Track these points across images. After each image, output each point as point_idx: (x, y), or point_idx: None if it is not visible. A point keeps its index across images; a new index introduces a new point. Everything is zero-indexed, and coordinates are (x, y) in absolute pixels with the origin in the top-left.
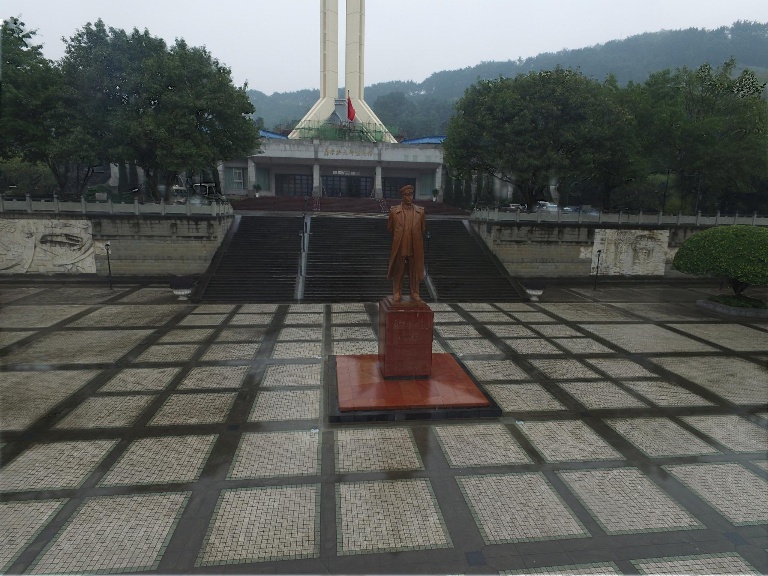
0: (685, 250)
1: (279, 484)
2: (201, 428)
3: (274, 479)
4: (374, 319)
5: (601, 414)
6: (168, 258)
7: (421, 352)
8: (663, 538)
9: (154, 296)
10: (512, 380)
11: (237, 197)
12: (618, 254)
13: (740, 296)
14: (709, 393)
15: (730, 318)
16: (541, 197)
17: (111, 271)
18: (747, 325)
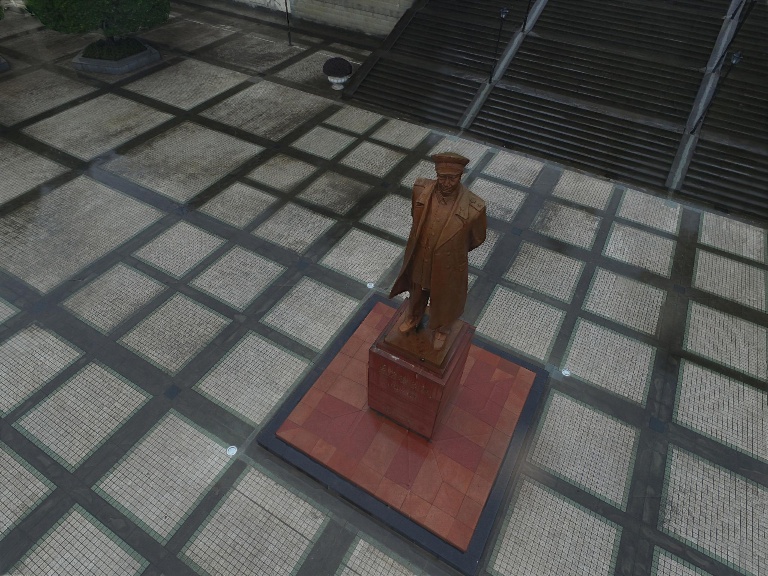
0: None
1: (119, 533)
2: (149, 374)
3: (123, 520)
4: (522, 214)
5: None
6: (358, 7)
7: (419, 413)
8: None
9: (317, 72)
10: (583, 492)
11: None
12: None
13: None
14: None
15: None
16: None
17: (303, 13)
18: None
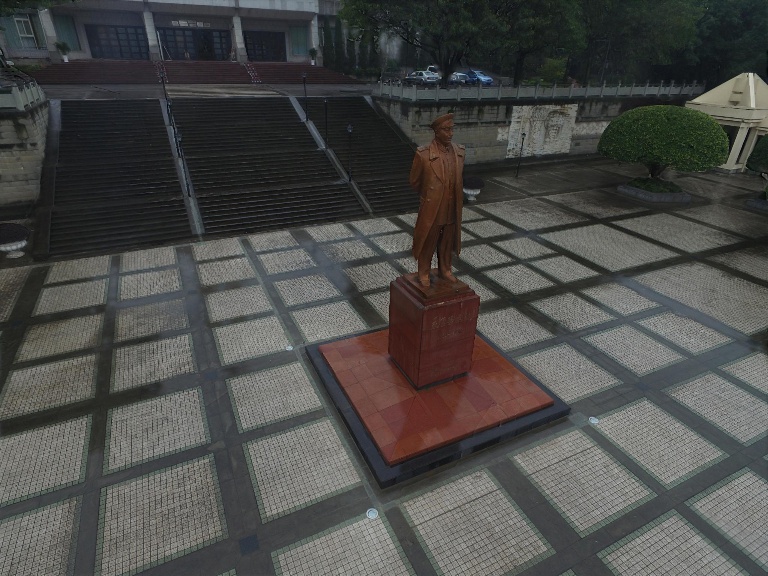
0: (616, 134)
1: None
2: (197, 563)
3: None
4: (318, 258)
5: (656, 382)
6: None
7: (462, 348)
8: None
9: None
10: (537, 343)
11: (32, 62)
12: (532, 133)
13: (657, 180)
14: (716, 322)
15: (654, 205)
16: (458, 68)
17: None
18: (673, 214)
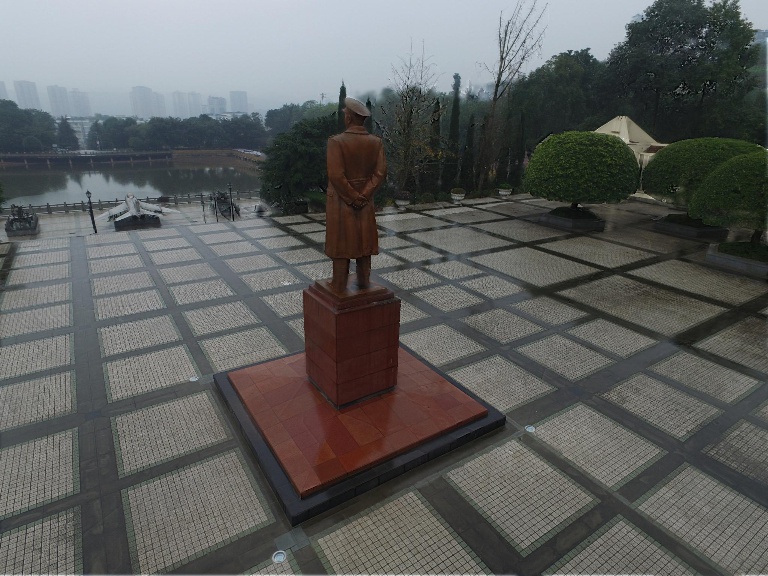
0: None
1: None
2: (464, 313)
3: None
4: None
5: (66, 422)
6: None
7: None
8: (136, 318)
9: None
10: (172, 469)
11: None
12: None
13: None
14: None
15: None
16: None
17: None
18: None
